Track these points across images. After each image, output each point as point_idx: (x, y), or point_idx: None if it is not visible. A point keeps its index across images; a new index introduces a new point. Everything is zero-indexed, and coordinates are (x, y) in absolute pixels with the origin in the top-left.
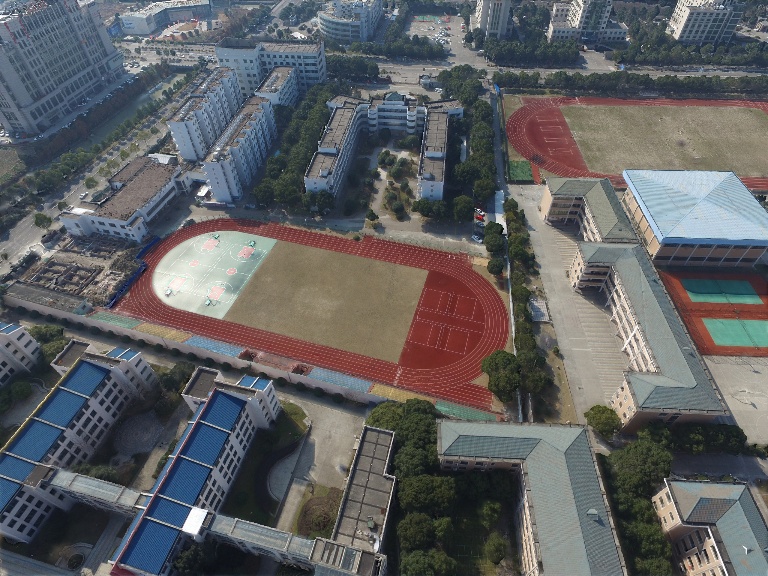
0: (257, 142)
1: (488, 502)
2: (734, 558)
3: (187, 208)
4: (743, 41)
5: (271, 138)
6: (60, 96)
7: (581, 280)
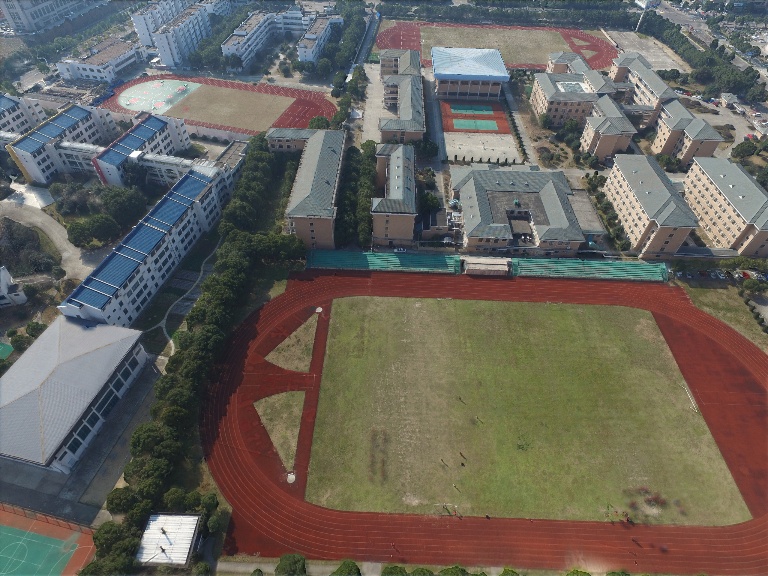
0: (194, 32)
1: (290, 161)
2: None
3: (143, 69)
4: None
5: (207, 35)
6: (52, 6)
7: (385, 98)
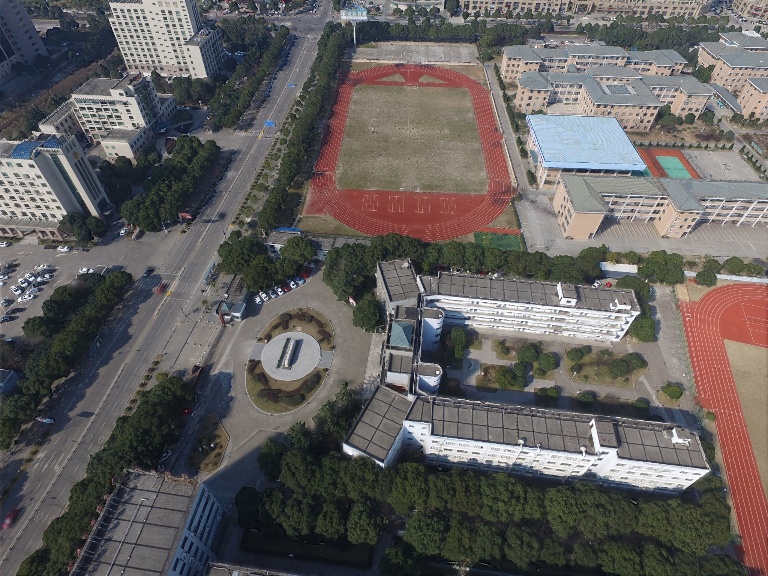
0: None
1: None
2: None
3: None
4: None
5: None
6: None
7: None
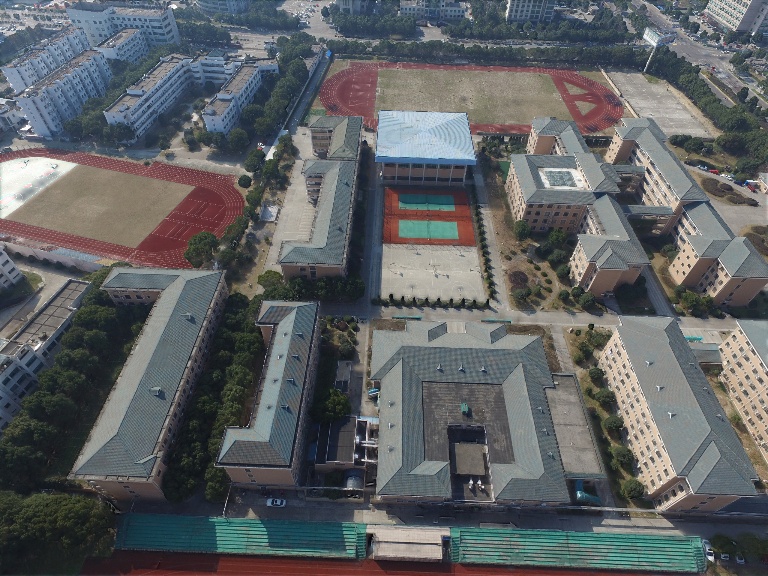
0: (84, 88)
1: (138, 322)
2: (276, 340)
3: (10, 140)
4: (570, 22)
5: (106, 88)
6: None
7: (309, 191)
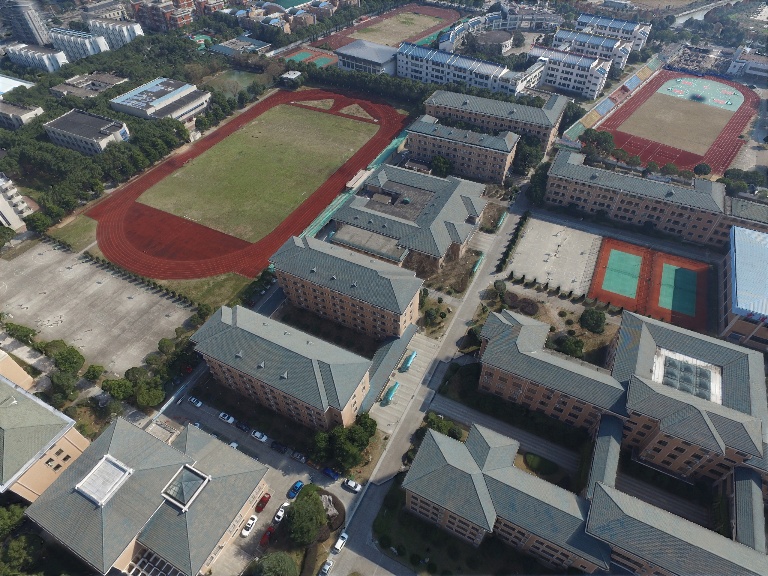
0: None
1: None
2: None
3: None
4: None
5: None
6: None
7: None
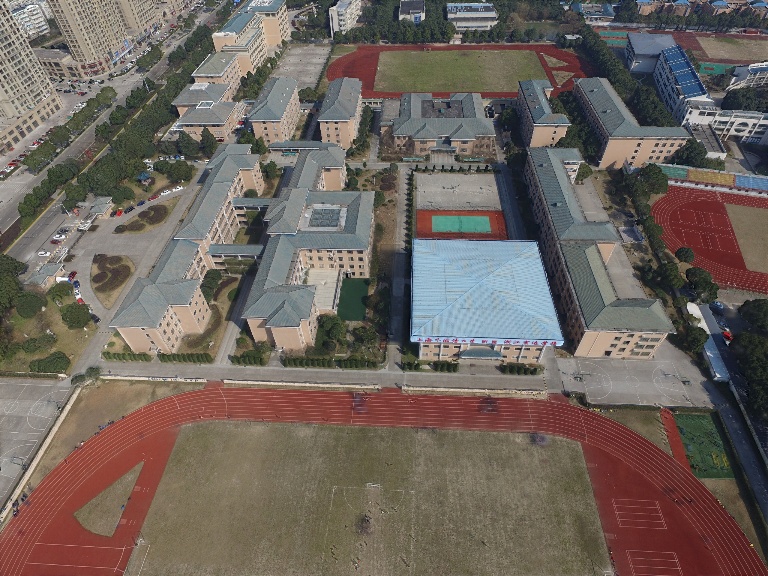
0: None
1: None
2: None
3: None
4: None
5: None
6: None
7: None
